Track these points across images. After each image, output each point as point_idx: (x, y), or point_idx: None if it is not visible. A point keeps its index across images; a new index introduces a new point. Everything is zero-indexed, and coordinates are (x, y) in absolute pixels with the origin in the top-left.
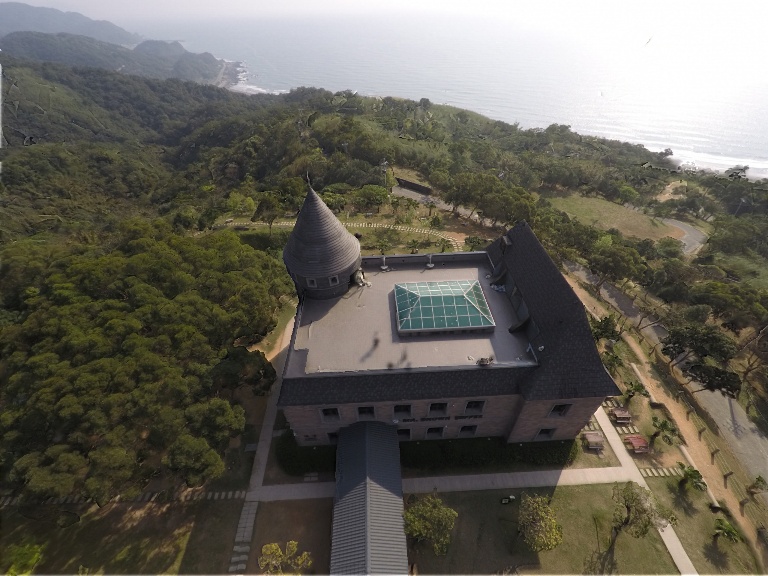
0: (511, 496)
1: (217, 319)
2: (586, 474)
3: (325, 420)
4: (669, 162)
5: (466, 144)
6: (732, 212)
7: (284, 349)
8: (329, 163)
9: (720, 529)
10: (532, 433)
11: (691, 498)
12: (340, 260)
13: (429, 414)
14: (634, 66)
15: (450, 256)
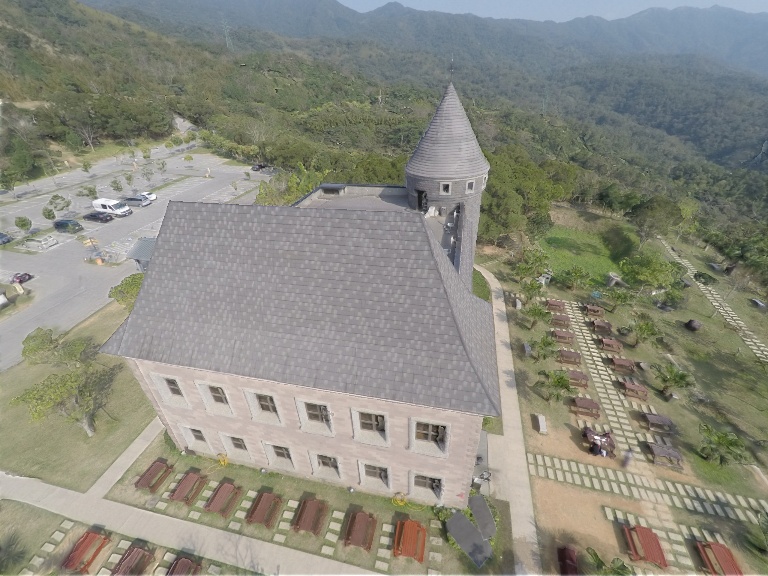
0: None
1: None
2: (144, 442)
3: None
4: None
5: None
6: None
7: None
8: None
9: None
10: None
11: None
12: (416, 164)
13: None
14: None
15: None
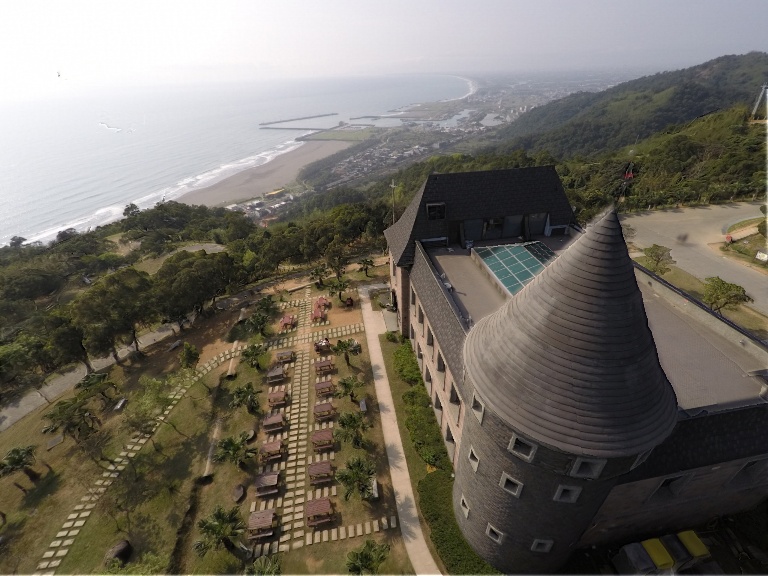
0: None
1: None
2: None
3: None
4: (112, 214)
5: None
6: (178, 228)
7: None
8: None
9: None
10: None
11: None
12: None
13: None
14: (89, 98)
15: None
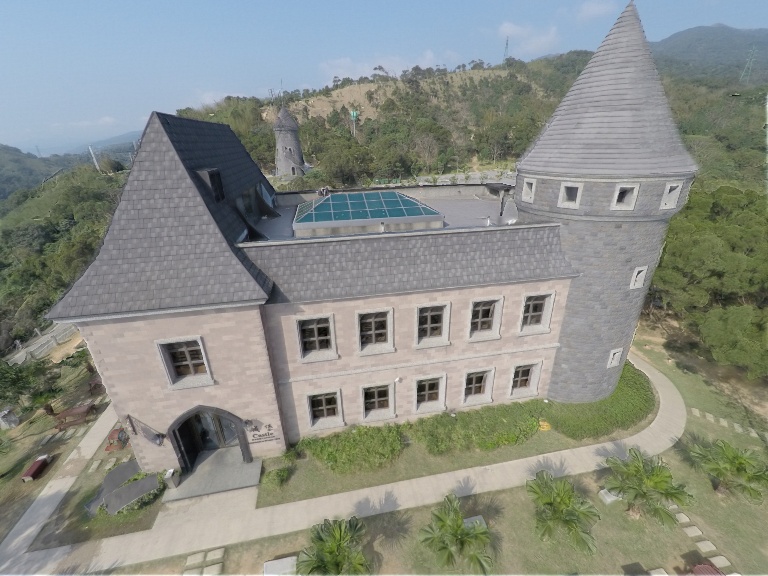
0: None
1: None
2: None
3: None
4: None
5: None
6: None
7: None
8: None
9: None
10: None
11: None
12: None
13: None
14: None
15: None
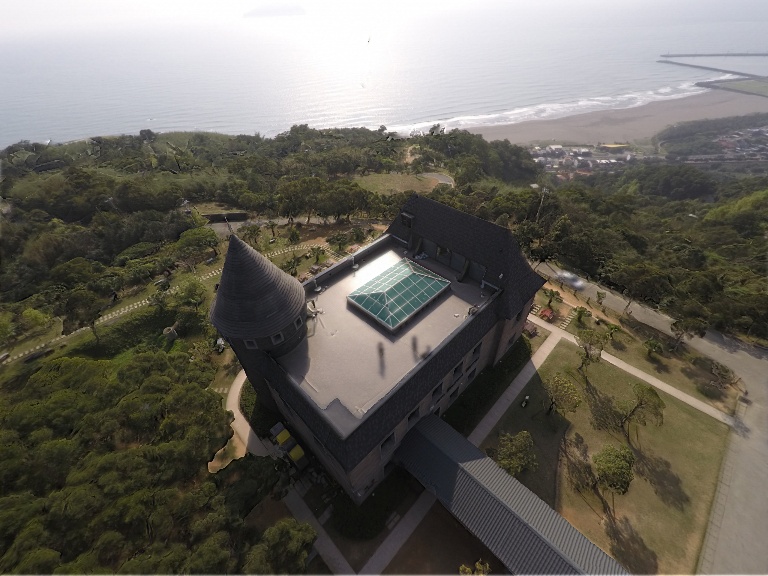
0: (526, 397)
1: (174, 456)
2: (542, 351)
3: (383, 454)
4: (403, 132)
5: (244, 161)
6: (449, 156)
7: (249, 440)
8: (96, 229)
9: (612, 329)
10: (505, 347)
11: (588, 324)
12: (295, 299)
13: (452, 381)
14: (371, 61)
15: (366, 251)
